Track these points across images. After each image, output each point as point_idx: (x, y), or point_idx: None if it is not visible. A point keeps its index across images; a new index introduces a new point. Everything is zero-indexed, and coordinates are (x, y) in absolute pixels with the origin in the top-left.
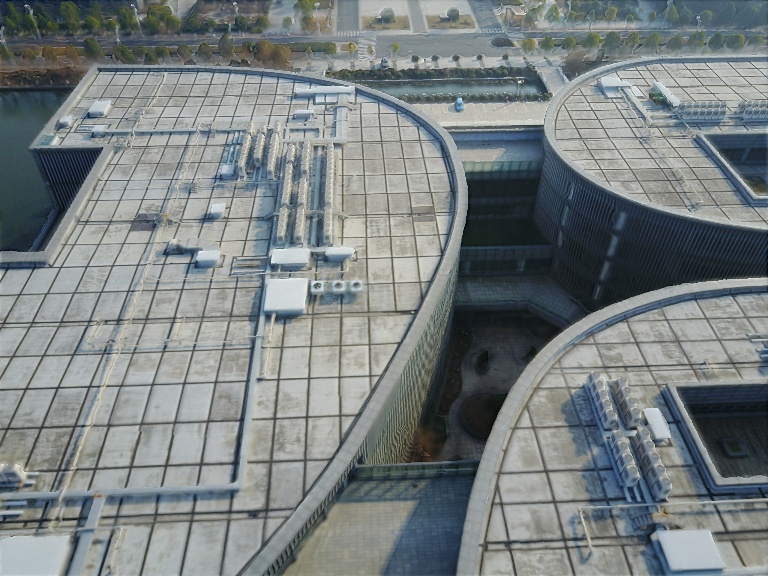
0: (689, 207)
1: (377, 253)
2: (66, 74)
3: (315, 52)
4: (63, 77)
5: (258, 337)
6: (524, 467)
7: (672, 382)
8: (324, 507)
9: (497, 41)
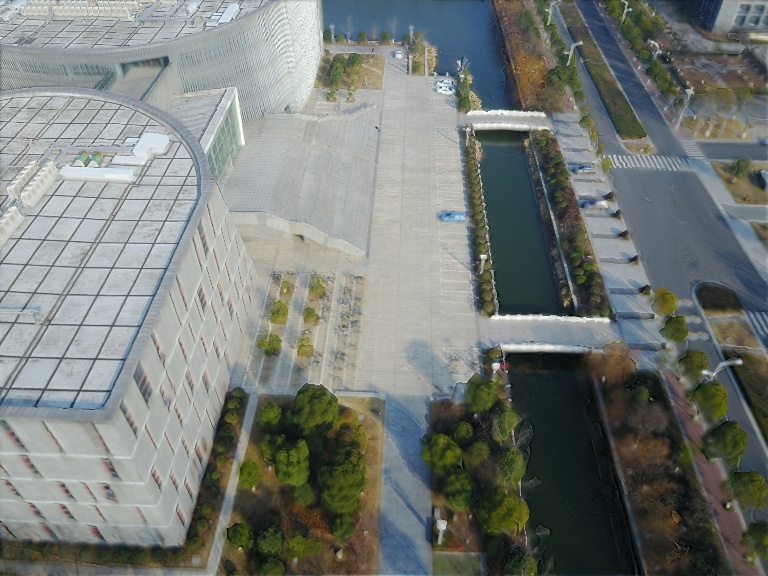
0: None
1: None
2: (510, 14)
3: (613, 126)
4: (508, 14)
5: None
6: None
7: None
8: None
9: (720, 290)
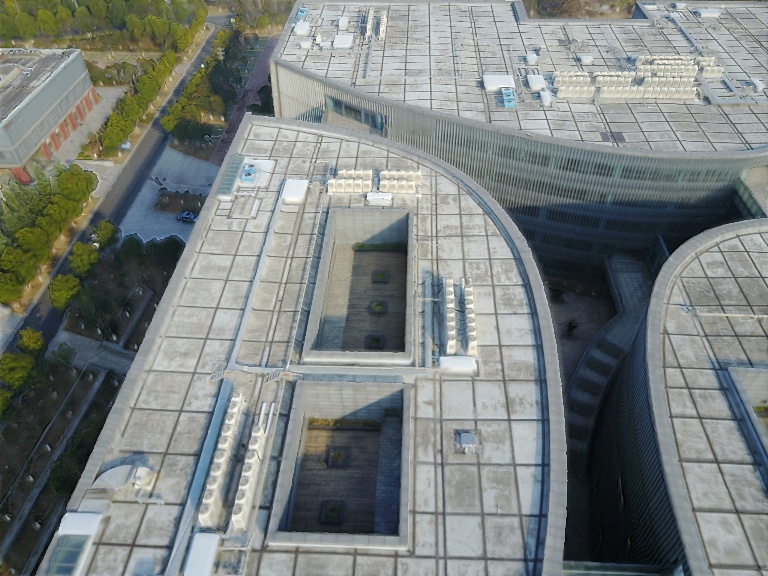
0: (691, 308)
1: (551, 114)
2: None
3: None
4: None
5: (462, 76)
6: (361, 151)
7: (413, 211)
8: (357, 106)
9: None
